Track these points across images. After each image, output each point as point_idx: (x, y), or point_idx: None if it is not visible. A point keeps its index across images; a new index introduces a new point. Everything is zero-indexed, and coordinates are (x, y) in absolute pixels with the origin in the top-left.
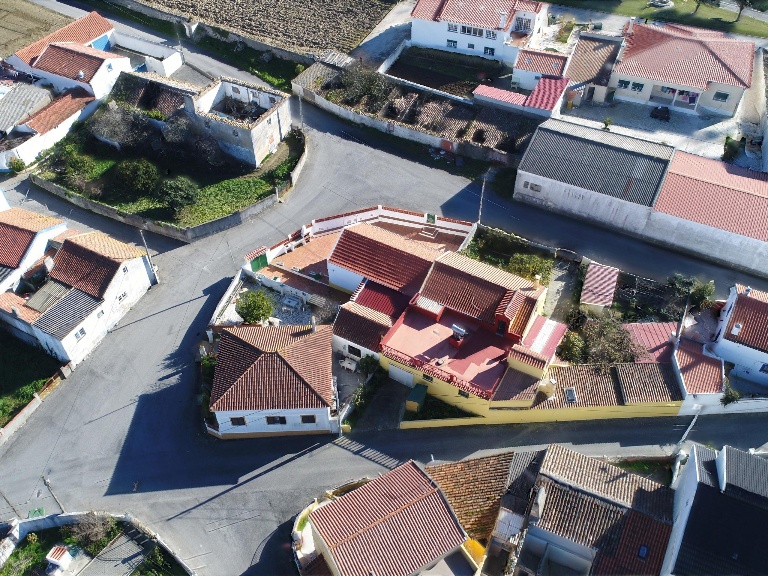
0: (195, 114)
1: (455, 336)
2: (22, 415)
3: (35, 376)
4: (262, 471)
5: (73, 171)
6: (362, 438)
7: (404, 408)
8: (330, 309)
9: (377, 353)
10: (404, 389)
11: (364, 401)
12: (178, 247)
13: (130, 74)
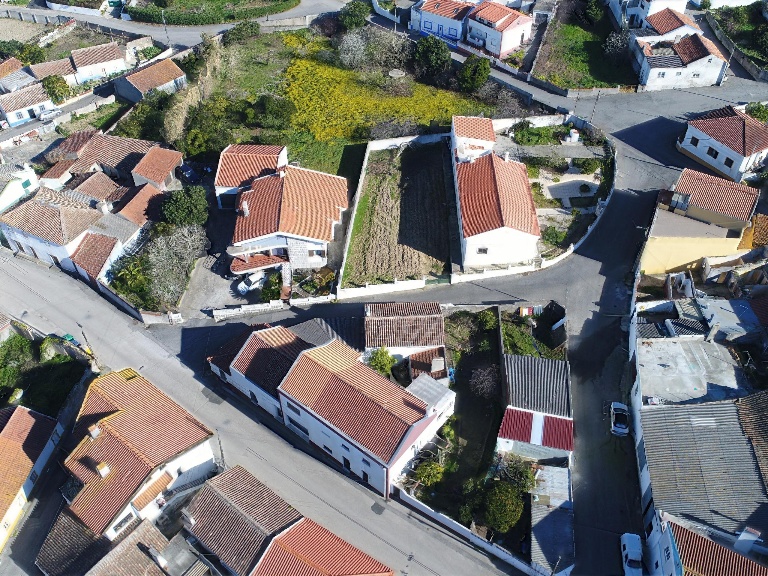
0: None
1: None
2: (607, 90)
3: (626, 83)
4: None
5: (732, 22)
6: None
7: None
8: None
9: None
10: None
11: (767, 178)
12: (749, 79)
13: None
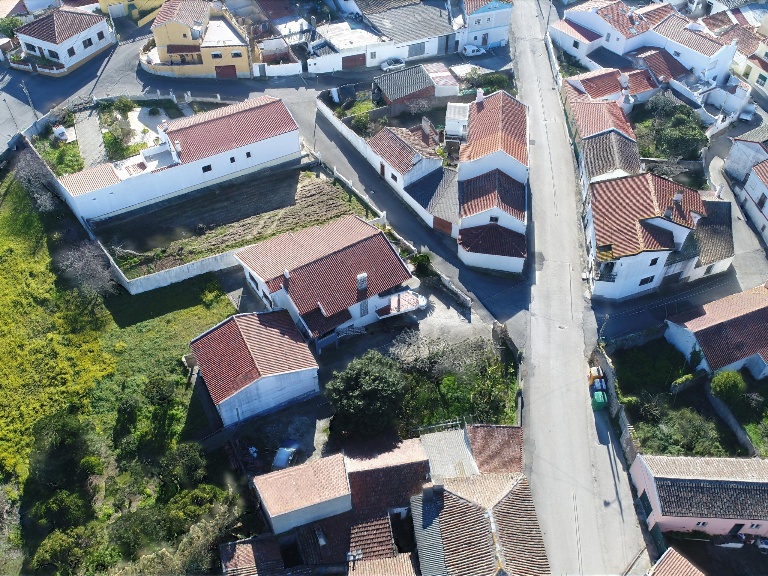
0: None
1: None
2: None
3: None
4: (103, 68)
5: None
6: (129, 38)
7: (132, 22)
8: (51, 9)
9: None
10: (123, 18)
11: (114, 23)
12: None
13: None
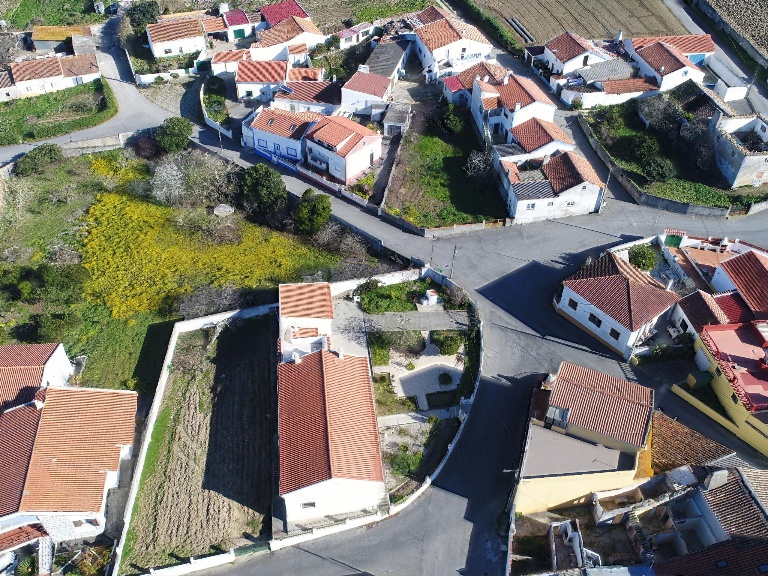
0: (715, 127)
1: (764, 359)
2: (470, 227)
3: (492, 214)
4: (563, 342)
5: (607, 125)
6: (640, 374)
7: None
8: None
9: (697, 333)
10: None
11: (661, 354)
12: (630, 202)
13: (695, 83)
